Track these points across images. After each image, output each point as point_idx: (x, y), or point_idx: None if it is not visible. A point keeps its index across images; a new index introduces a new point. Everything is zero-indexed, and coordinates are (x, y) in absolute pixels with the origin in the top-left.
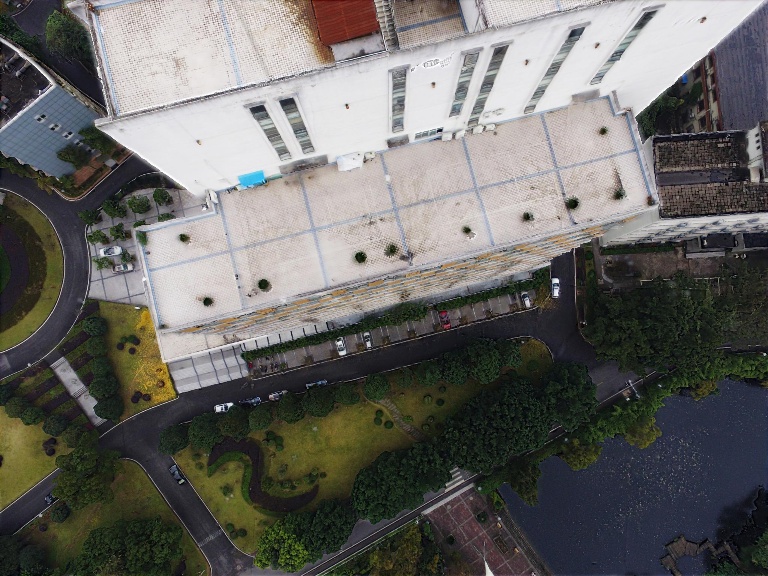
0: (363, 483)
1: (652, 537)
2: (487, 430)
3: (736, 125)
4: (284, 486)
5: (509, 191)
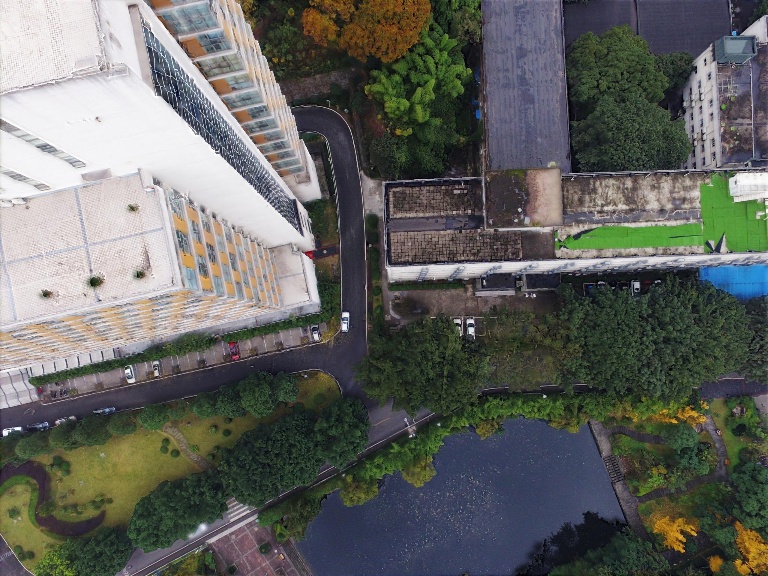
0: (137, 512)
1: (437, 573)
2: (251, 465)
3: (504, 167)
4: (67, 511)
5: (36, 266)
